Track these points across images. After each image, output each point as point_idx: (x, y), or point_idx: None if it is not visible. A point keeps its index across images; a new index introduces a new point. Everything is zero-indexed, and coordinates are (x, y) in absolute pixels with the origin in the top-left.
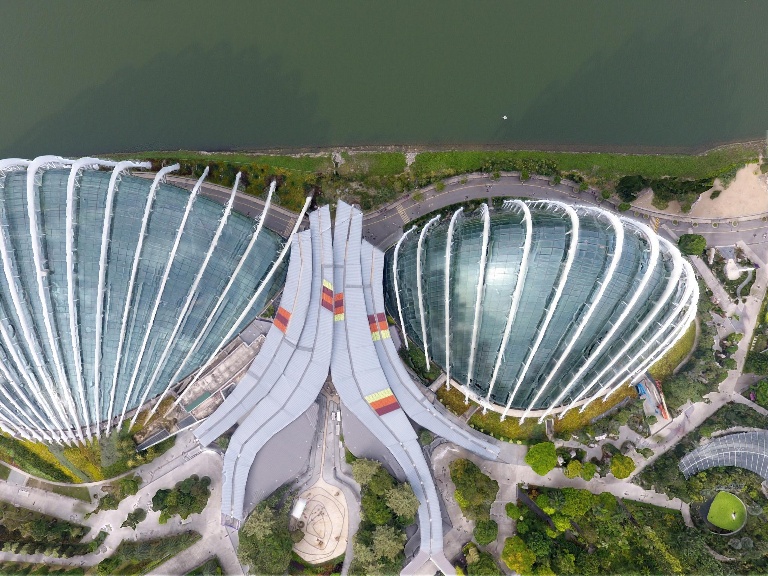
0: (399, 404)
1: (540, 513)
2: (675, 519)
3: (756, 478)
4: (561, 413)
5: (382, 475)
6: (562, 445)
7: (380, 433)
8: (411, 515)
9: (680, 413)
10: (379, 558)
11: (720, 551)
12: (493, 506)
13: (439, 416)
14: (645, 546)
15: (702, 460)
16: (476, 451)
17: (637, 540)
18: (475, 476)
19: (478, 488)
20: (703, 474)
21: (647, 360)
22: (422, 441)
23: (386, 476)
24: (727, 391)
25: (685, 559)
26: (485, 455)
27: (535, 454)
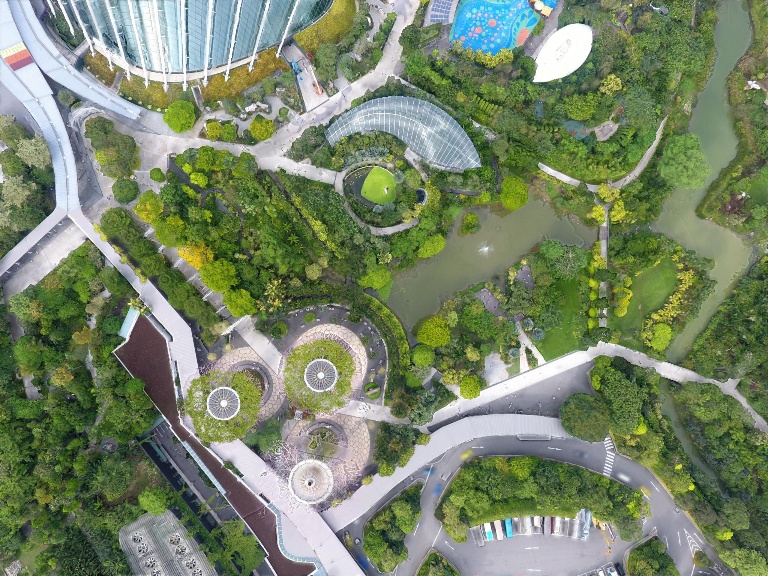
0: (33, 58)
1: (191, 184)
2: (325, 190)
3: (394, 140)
4: (204, 77)
5: (12, 125)
6: (214, 117)
7: (14, 88)
8: (41, 165)
9: (334, 89)
10: (8, 206)
11: (363, 216)
12: (144, 176)
13: (76, 74)
14: (290, 212)
15: (345, 126)
16: (115, 110)
17: (283, 206)
18: (105, 126)
19: (112, 143)
20: (343, 137)
21: (267, 4)
22: (58, 98)
23: (17, 128)
24: (386, 73)
25: (311, 207)
26: (124, 114)
27: (169, 109)
